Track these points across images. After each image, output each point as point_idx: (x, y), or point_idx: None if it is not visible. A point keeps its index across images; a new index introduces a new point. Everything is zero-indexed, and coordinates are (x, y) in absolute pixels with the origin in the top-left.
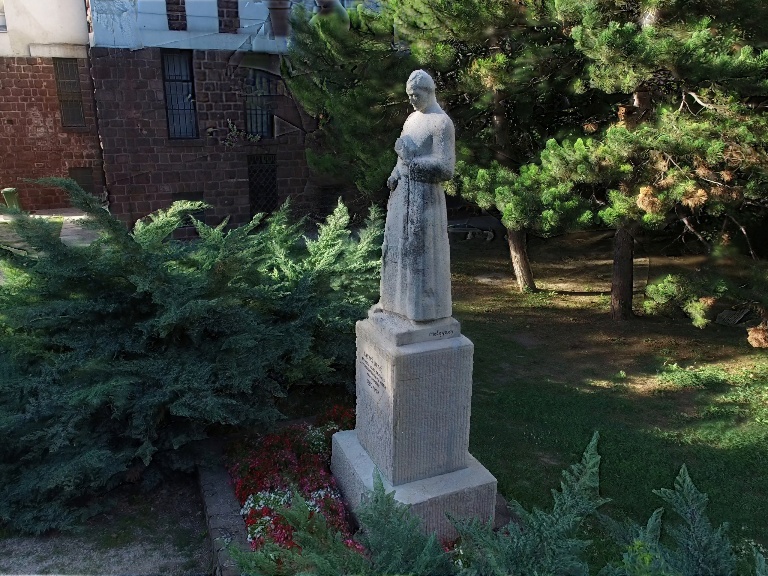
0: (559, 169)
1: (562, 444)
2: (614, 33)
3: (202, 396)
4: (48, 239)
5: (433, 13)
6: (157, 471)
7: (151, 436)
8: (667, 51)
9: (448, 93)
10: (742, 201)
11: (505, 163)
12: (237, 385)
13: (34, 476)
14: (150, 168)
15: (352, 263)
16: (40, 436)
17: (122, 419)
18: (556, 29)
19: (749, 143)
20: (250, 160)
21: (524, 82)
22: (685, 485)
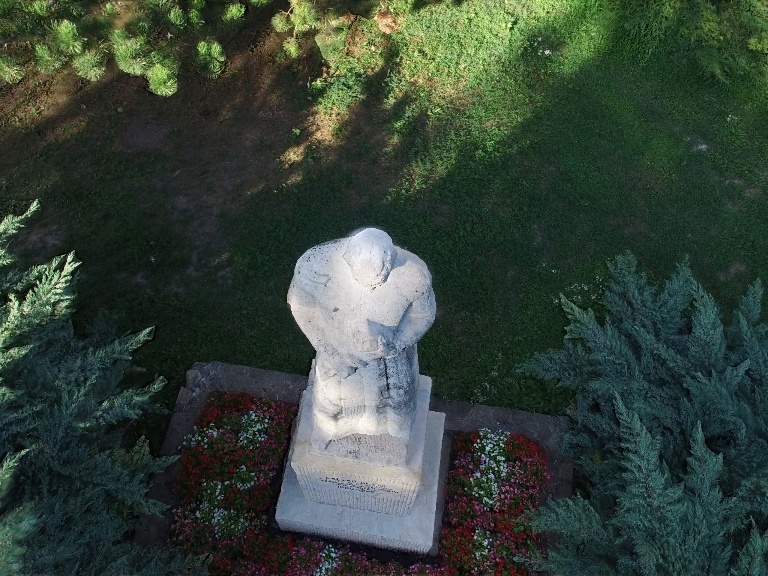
0: None
1: None
2: None
3: None
4: None
5: None
6: None
7: None
8: None
9: None
10: None
11: None
12: None
13: None
14: None
15: None
16: None
17: None
18: None
19: None
20: None
21: None
22: (577, 314)
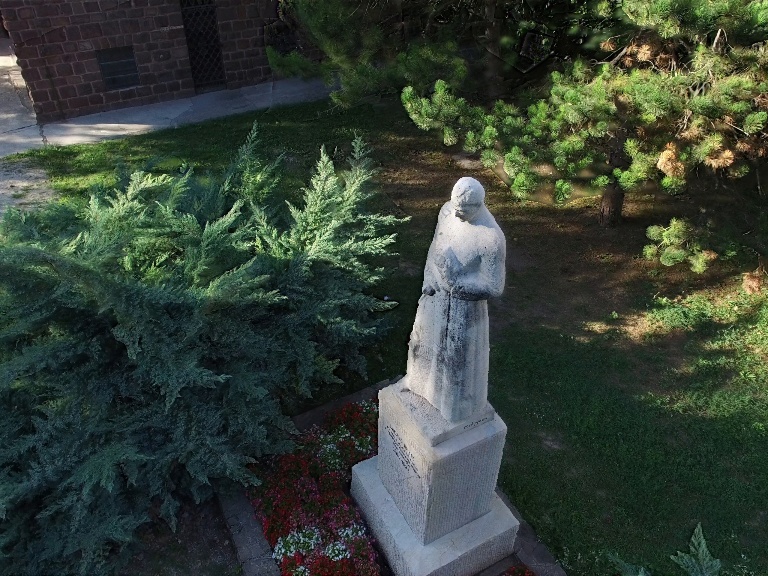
0: (575, 122)
1: (563, 423)
2: (673, 3)
3: (217, 451)
4: (0, 270)
5: None
6: (175, 497)
7: (169, 488)
8: (727, 13)
9: None
10: (767, 159)
11: (511, 100)
12: (251, 433)
13: (56, 536)
14: (63, 22)
15: (340, 217)
16: (55, 510)
17: (137, 479)
18: None
19: None
20: (183, 2)
21: None
22: (700, 550)
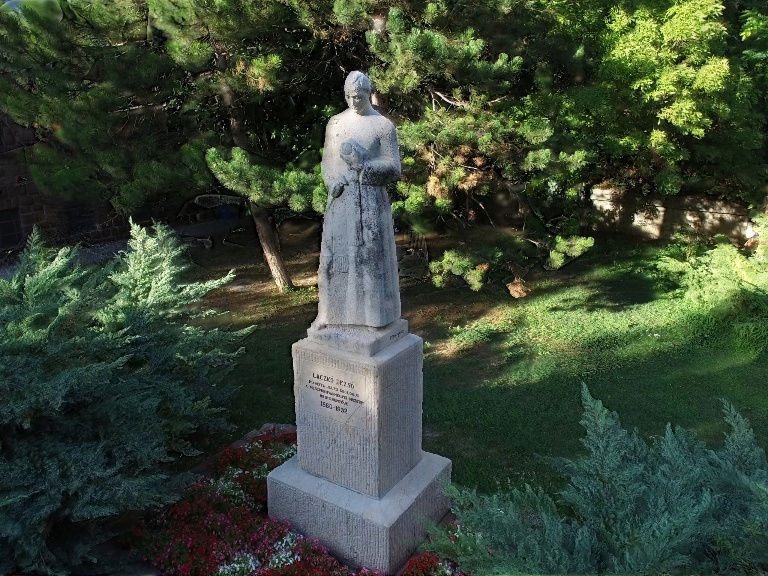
0: None
1: (433, 417)
2: (418, 39)
3: (111, 484)
4: None
5: (192, 8)
6: None
7: (48, 560)
8: (449, 56)
9: (200, 95)
10: (497, 181)
11: (297, 164)
12: (147, 457)
13: None
14: None
15: None
16: None
17: (2, 554)
18: (306, 31)
19: (501, 133)
20: None
21: (287, 83)
22: None
